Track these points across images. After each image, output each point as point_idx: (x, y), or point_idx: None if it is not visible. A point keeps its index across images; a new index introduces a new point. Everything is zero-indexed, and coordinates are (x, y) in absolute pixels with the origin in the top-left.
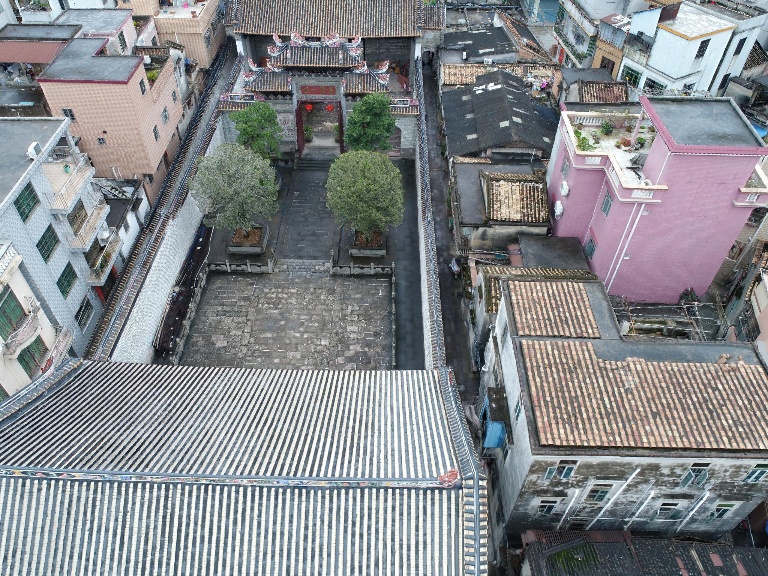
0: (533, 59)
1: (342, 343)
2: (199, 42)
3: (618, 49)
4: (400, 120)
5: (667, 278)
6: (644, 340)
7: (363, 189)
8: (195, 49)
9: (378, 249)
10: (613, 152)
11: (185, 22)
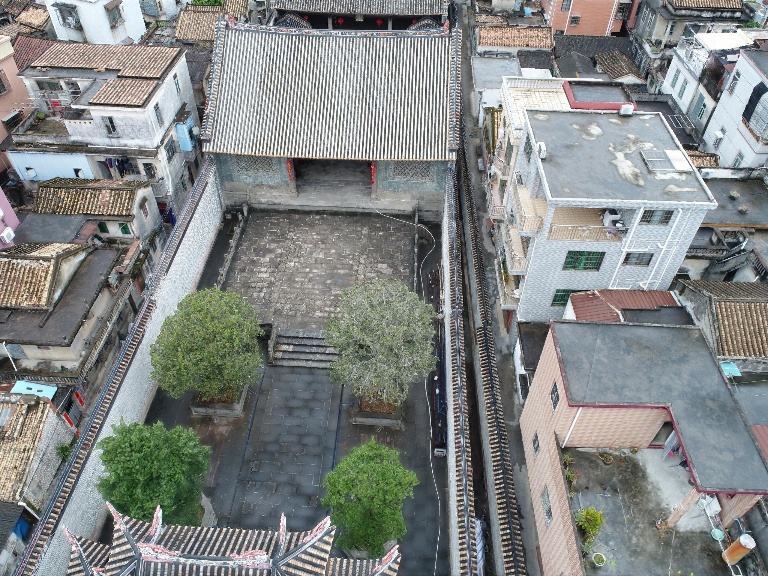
0: None
1: (275, 263)
2: None
3: None
4: None
5: None
6: (83, 77)
7: None
8: None
9: None
10: None
11: None
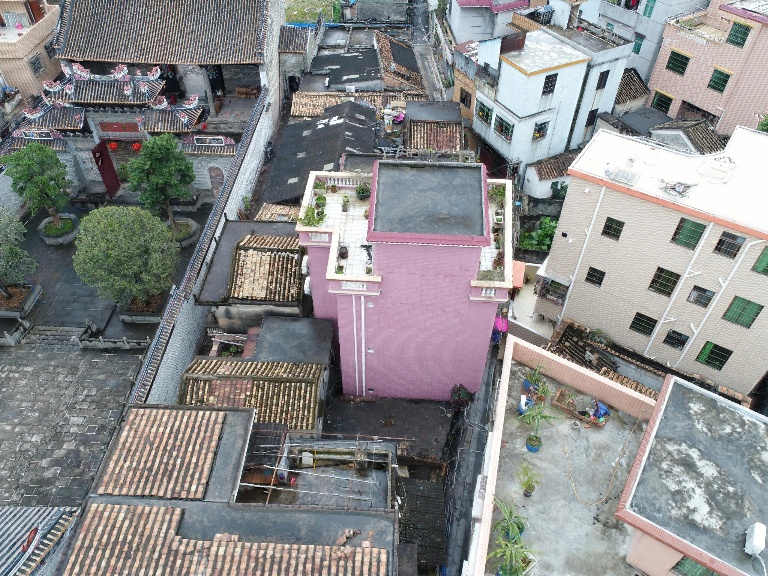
0: (401, 87)
1: (56, 440)
2: (22, 68)
3: (471, 81)
4: (218, 160)
5: (428, 373)
6: (256, 504)
7: (100, 255)
8: (20, 75)
9: (151, 315)
10: (357, 224)
11: (2, 46)
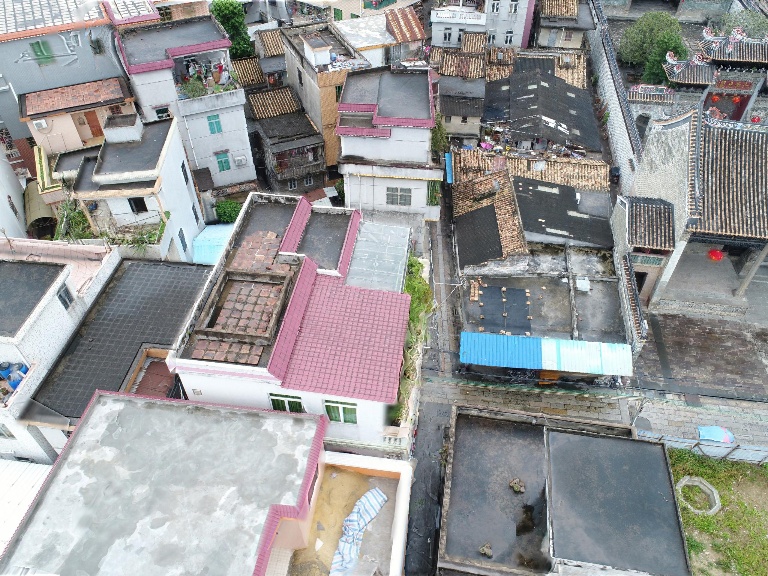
0: None
1: None
2: None
3: None
4: None
5: None
6: None
7: None
8: None
9: None
10: None
11: None
